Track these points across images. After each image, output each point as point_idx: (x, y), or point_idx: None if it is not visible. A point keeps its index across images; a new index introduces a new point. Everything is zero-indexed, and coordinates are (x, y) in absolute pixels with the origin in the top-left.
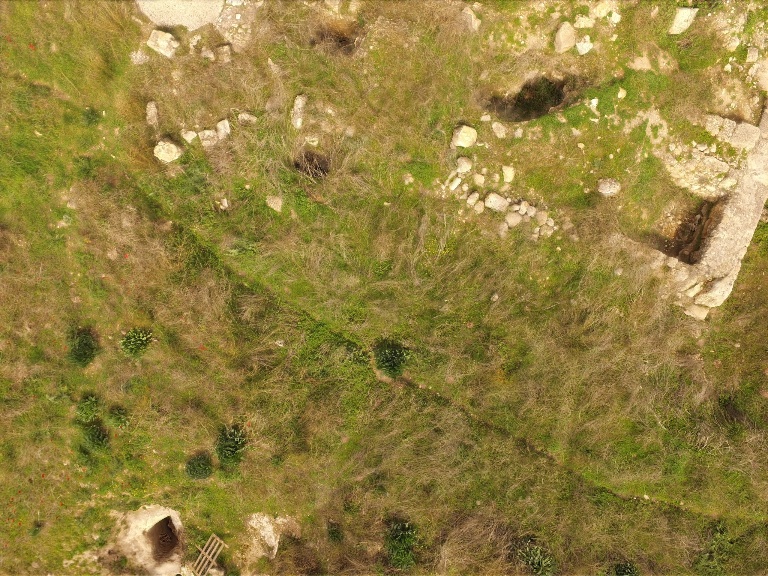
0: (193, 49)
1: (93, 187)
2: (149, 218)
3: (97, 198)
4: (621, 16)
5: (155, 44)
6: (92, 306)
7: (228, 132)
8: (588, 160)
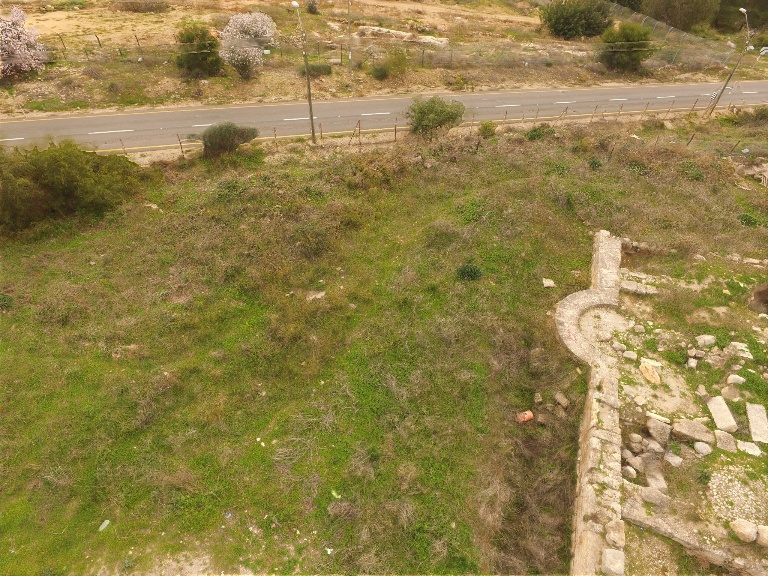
0: None
1: None
2: None
3: None
4: None
5: None
6: None
7: None
8: None
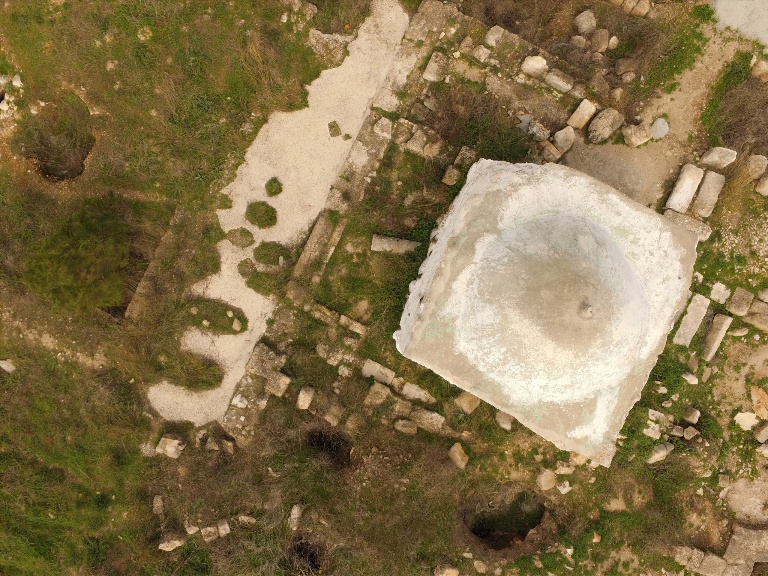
0: (199, 442)
1: None
2: None
3: None
4: None
5: (163, 450)
6: None
7: (228, 532)
8: None
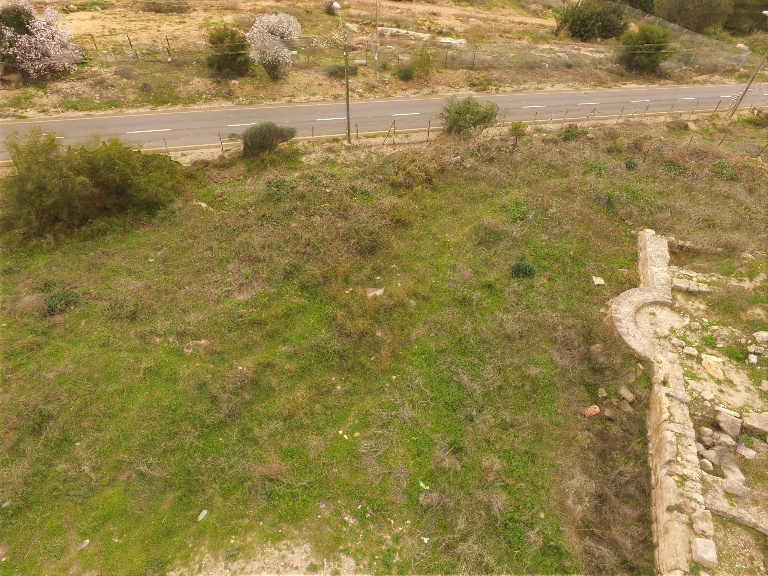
0: None
1: None
2: None
3: None
4: None
5: None
6: None
7: None
8: None
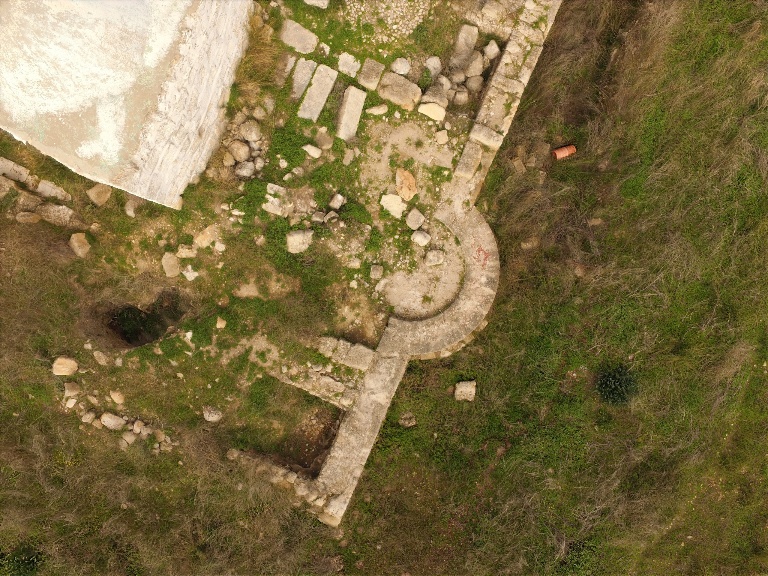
0: None
1: None
2: None
3: None
4: (225, 245)
5: None
6: None
7: None
8: (190, 387)
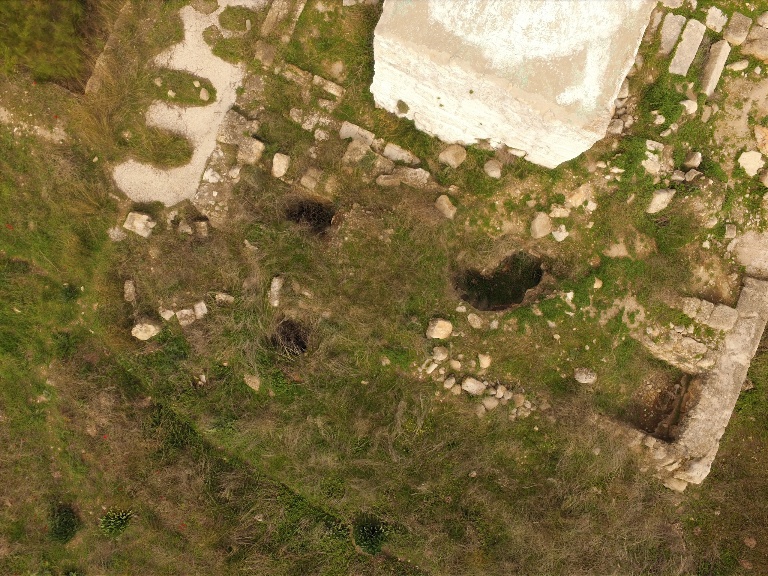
0: (170, 224)
1: (72, 368)
2: (128, 397)
3: (76, 378)
4: (597, 204)
5: (132, 226)
6: (72, 480)
7: (205, 313)
8: (564, 349)
